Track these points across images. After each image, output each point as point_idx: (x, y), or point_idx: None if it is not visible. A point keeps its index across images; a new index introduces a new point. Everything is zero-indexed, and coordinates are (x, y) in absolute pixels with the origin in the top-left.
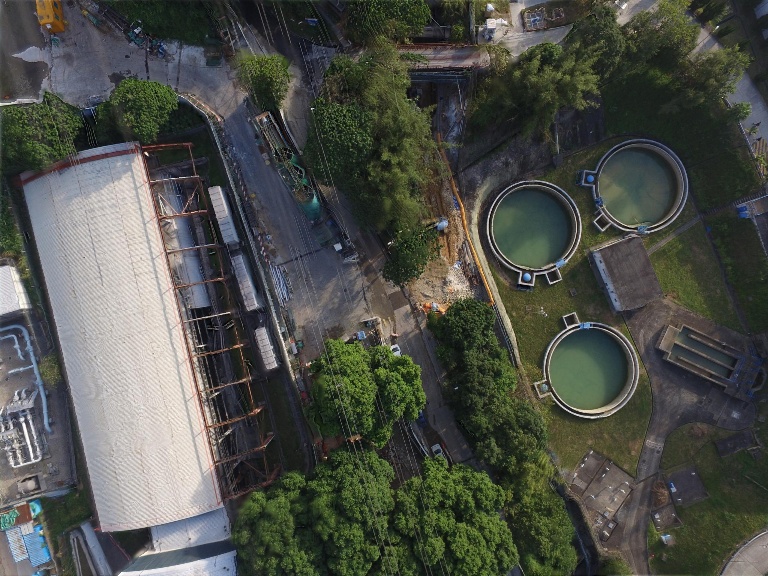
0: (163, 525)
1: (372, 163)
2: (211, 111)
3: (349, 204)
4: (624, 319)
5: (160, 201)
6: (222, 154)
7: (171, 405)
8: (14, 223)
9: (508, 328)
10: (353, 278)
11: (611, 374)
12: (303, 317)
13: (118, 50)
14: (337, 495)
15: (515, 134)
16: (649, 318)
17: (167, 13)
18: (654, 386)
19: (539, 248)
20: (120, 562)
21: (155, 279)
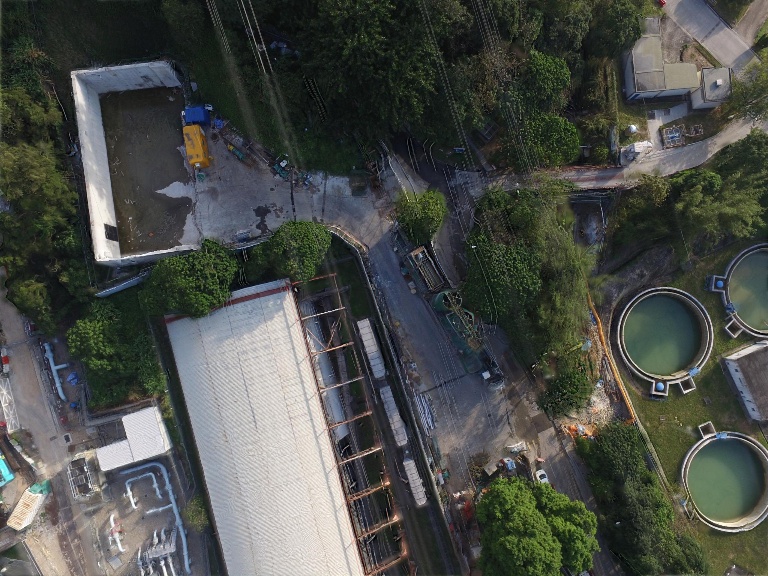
0: None
1: (542, 306)
2: (356, 241)
3: (507, 339)
4: (760, 427)
5: (307, 335)
6: (370, 286)
7: (330, 554)
8: (157, 362)
9: (648, 443)
10: (497, 402)
11: (747, 482)
12: (447, 444)
13: (263, 183)
14: None
15: (652, 247)
16: None
17: (317, 148)
18: None
19: (668, 354)
20: None
21: (310, 421)
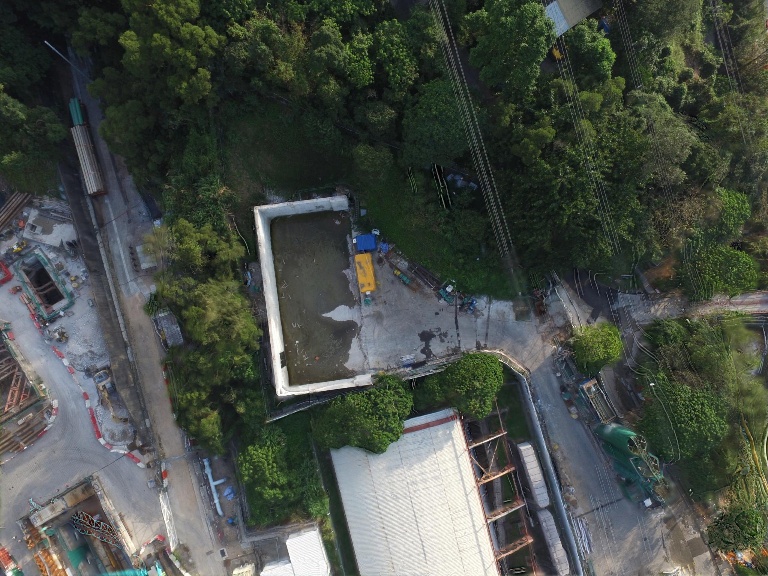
0: None
1: (729, 451)
2: (519, 365)
3: (680, 474)
4: None
5: None
6: None
7: None
8: (320, 485)
9: None
10: (653, 526)
11: None
12: (603, 569)
13: (428, 307)
14: None
15: None
16: None
17: (487, 277)
18: None
19: None
20: None
21: (479, 554)
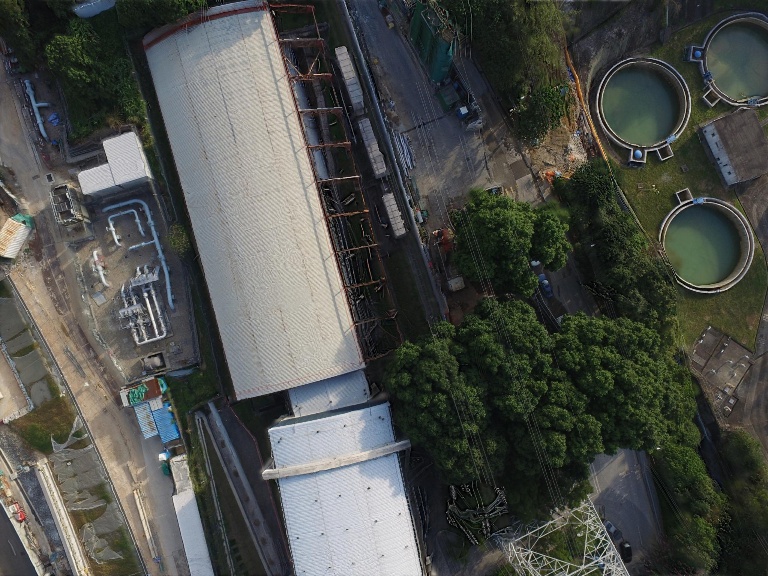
0: (304, 387)
1: (516, 3)
2: None
3: (483, 57)
4: (736, 194)
5: None
6: (348, 14)
7: (309, 264)
8: (137, 89)
9: (625, 201)
10: (475, 147)
11: (723, 252)
12: (426, 187)
13: None
14: (499, 332)
15: (629, 3)
16: (761, 192)
17: None
18: None
19: (647, 127)
20: (245, 444)
21: (288, 137)
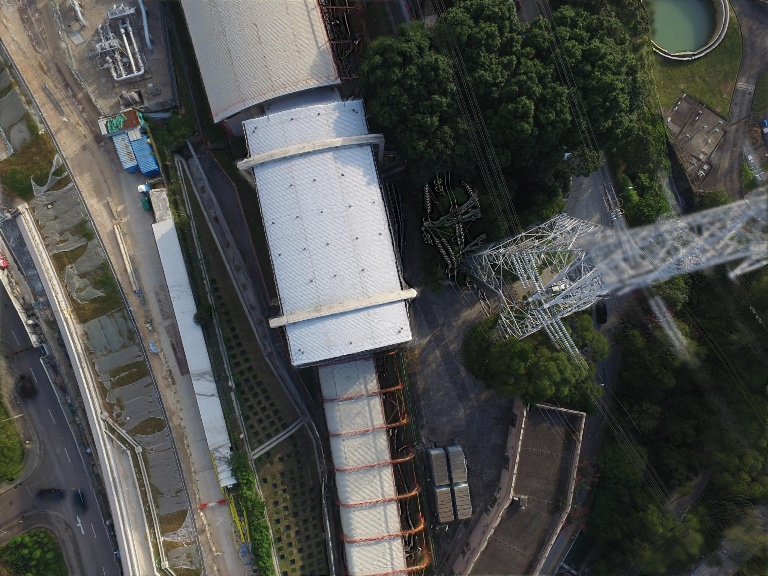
0: (280, 102)
1: None
2: None
3: None
4: None
5: None
6: None
7: None
8: None
9: None
10: None
11: (699, 25)
12: None
13: None
14: None
15: None
16: None
17: None
18: (744, 28)
19: None
20: (224, 190)
21: None
